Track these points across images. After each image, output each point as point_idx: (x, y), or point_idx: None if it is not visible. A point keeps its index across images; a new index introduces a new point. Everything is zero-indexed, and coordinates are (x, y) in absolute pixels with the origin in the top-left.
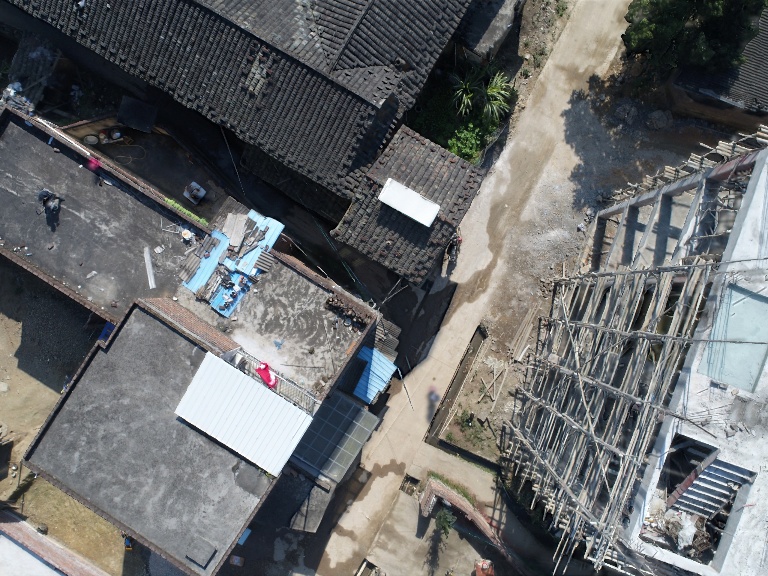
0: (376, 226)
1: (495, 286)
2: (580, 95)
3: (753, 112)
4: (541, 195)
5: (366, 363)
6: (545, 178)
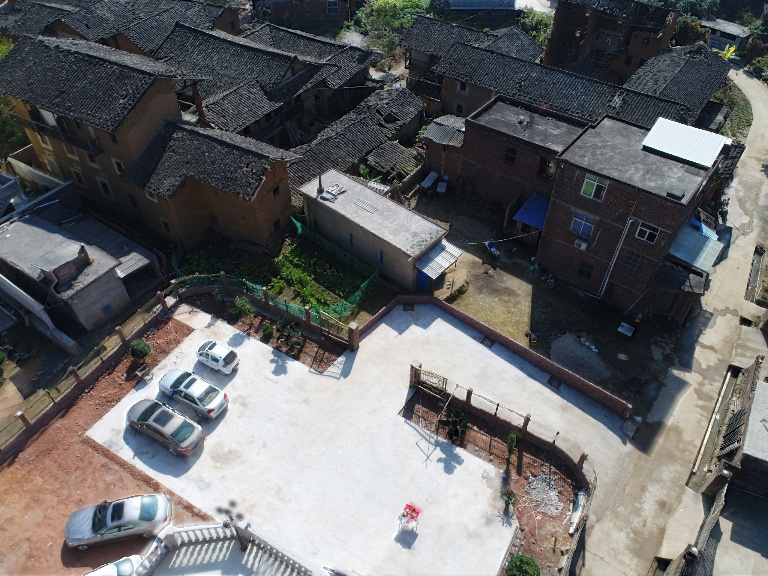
0: None
1: (758, 230)
2: (767, 166)
3: None
4: (766, 197)
5: (699, 228)
6: (765, 191)
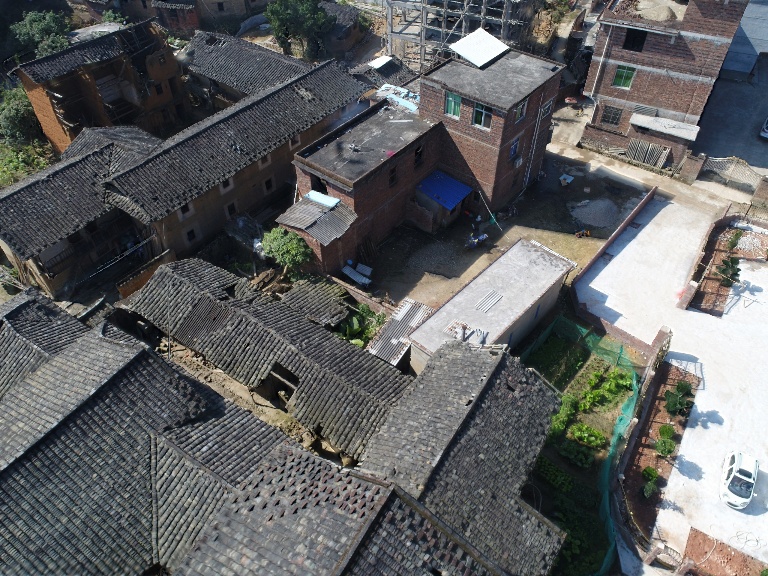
0: (389, 80)
1: None
2: None
3: (354, 28)
4: None
5: None
6: None
